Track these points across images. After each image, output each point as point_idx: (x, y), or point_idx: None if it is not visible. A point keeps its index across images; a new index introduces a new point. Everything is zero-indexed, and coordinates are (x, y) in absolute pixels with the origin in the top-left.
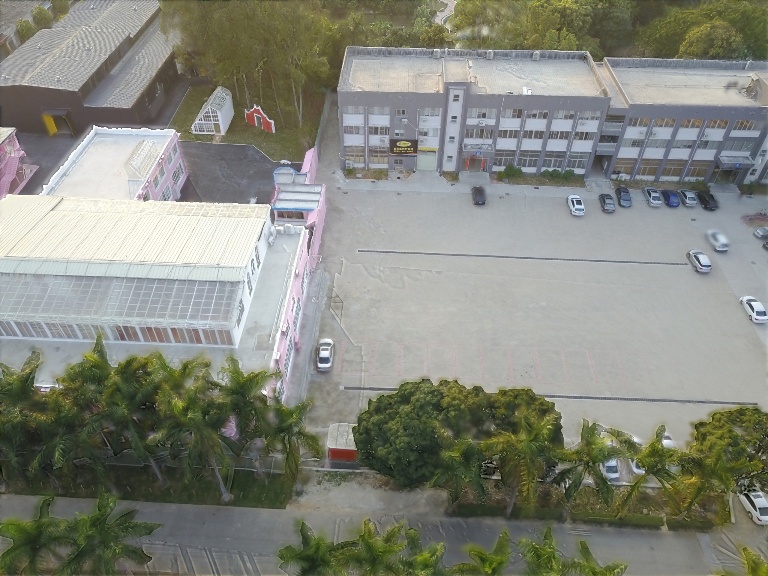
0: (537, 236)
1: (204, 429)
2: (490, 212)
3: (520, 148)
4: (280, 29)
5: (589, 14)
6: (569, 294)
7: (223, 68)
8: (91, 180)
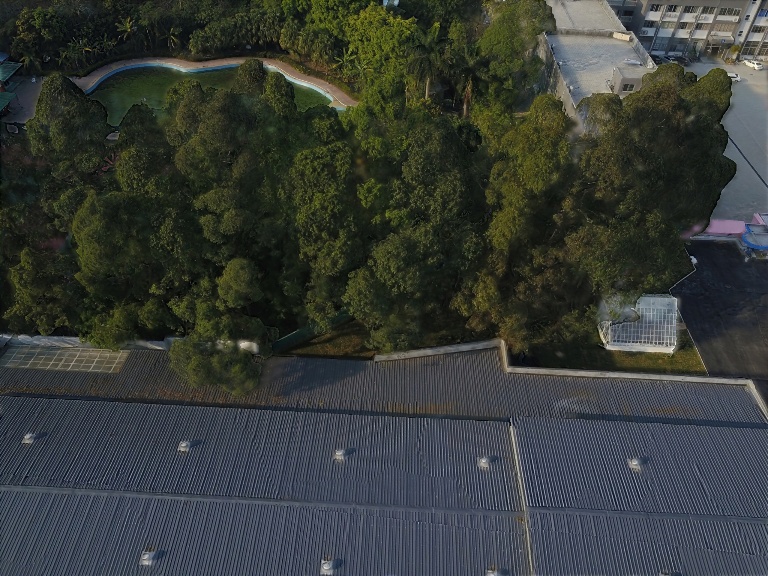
0: None
1: None
2: None
3: None
4: None
5: None
6: (763, 131)
7: None
8: None
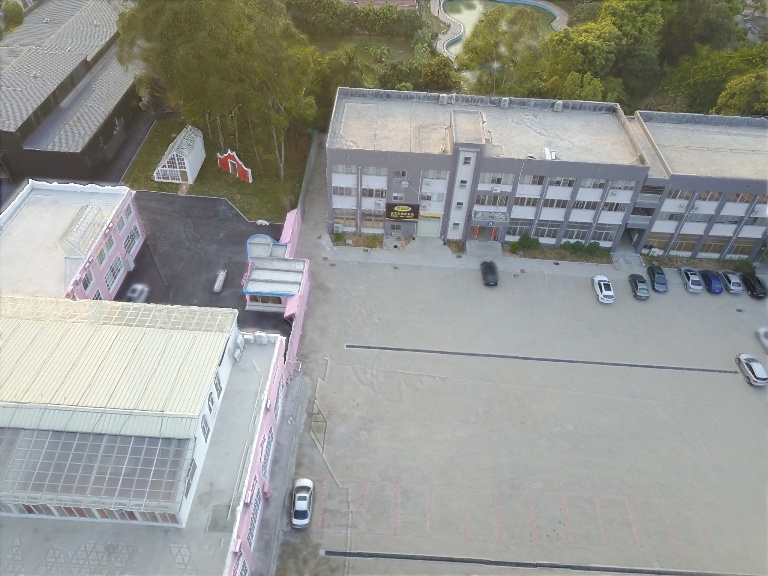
0: (559, 329)
1: None
2: (503, 295)
3: (539, 217)
4: (259, 71)
5: (612, 51)
6: (601, 413)
7: (191, 109)
8: (18, 256)
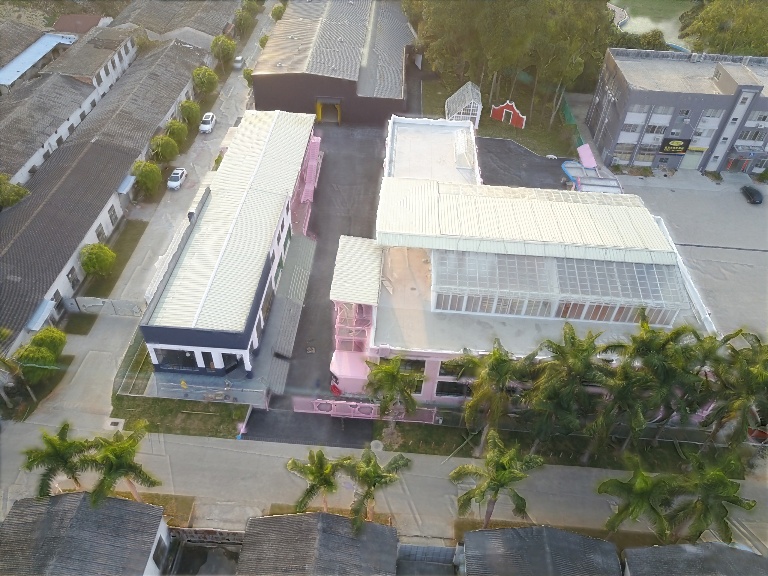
0: None
1: (761, 397)
2: (767, 211)
3: None
4: (580, 28)
5: None
6: None
7: (496, 64)
8: (421, 167)
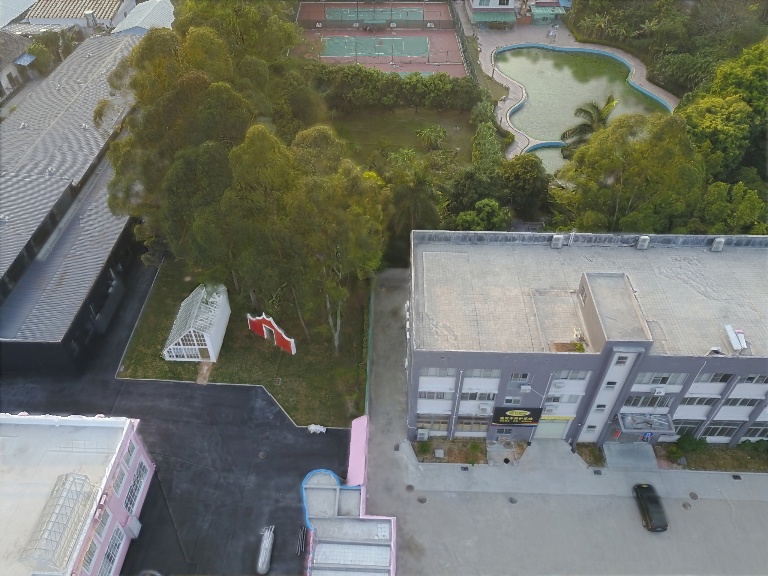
0: None
1: None
2: (677, 547)
3: (713, 418)
4: (312, 246)
5: (746, 136)
6: None
7: (212, 277)
8: None
